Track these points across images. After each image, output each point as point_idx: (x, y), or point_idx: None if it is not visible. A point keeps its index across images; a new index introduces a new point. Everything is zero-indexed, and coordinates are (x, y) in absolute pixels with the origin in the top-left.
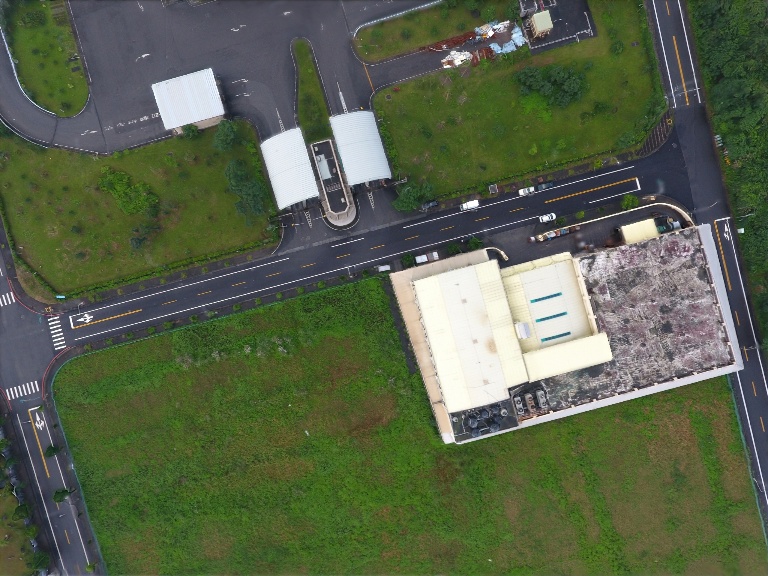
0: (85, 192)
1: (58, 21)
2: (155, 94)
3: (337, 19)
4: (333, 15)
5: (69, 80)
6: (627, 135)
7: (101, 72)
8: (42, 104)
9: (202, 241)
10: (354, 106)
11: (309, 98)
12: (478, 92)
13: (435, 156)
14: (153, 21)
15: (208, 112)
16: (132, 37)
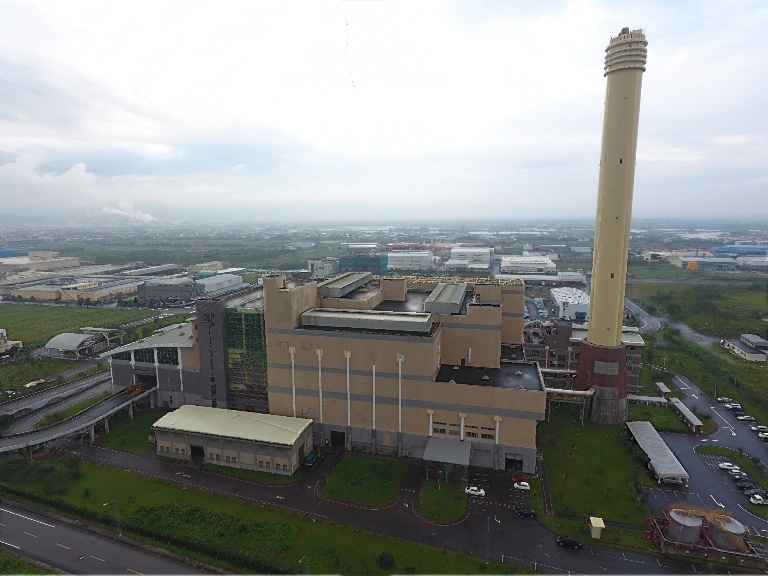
0: None
1: None
2: None
3: None
4: None
5: None
6: None
7: None
8: None
9: None
10: None
11: None
12: None
13: None
14: None
15: None
16: None
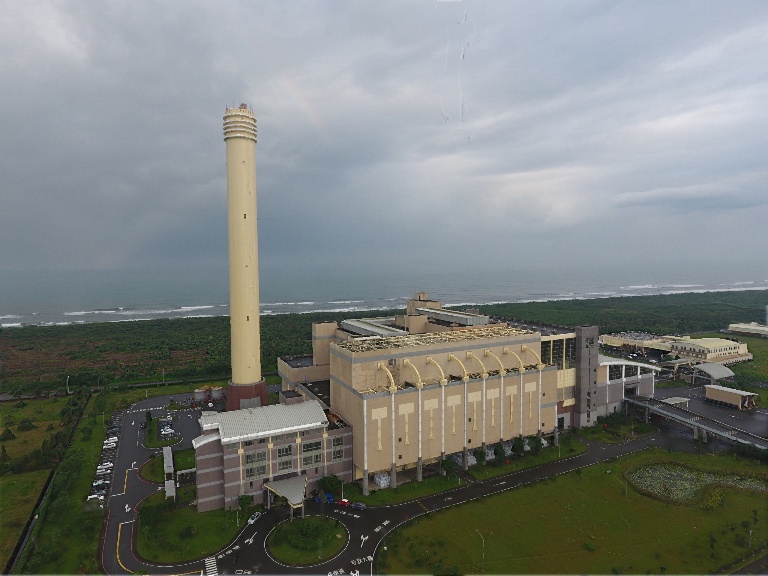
0: None
1: None
2: None
3: None
4: None
5: None
6: None
7: None
8: None
9: None
10: None
11: None
12: None
13: None
14: None
15: None
16: None
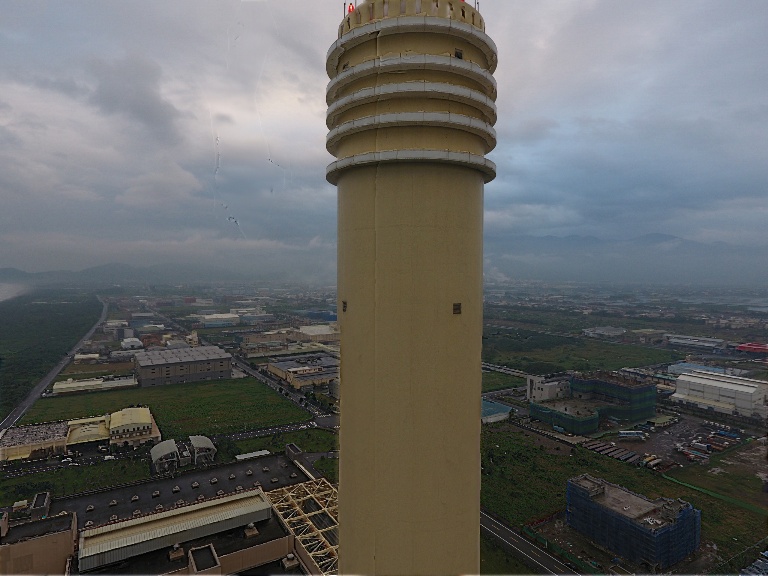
0: None
1: None
2: None
3: None
4: None
5: None
6: (2, 474)
7: None
8: None
9: None
10: None
11: None
12: (82, 486)
13: None
14: None
15: None
16: None
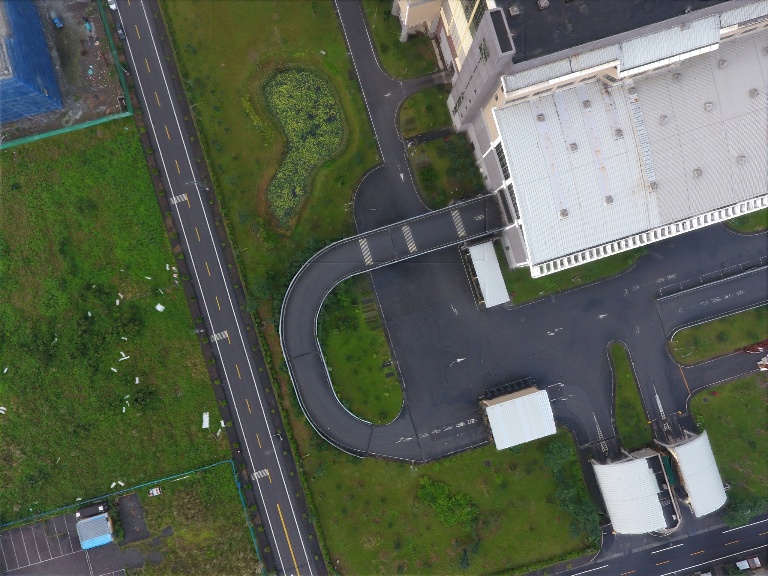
0: (402, 503)
1: (372, 327)
2: (489, 417)
3: (652, 321)
4: (648, 317)
5: (384, 387)
6: None
7: (415, 377)
8: (361, 416)
9: (521, 550)
10: (671, 409)
11: (628, 404)
12: None
13: (754, 460)
14: (467, 325)
15: (541, 432)
16: (446, 341)
